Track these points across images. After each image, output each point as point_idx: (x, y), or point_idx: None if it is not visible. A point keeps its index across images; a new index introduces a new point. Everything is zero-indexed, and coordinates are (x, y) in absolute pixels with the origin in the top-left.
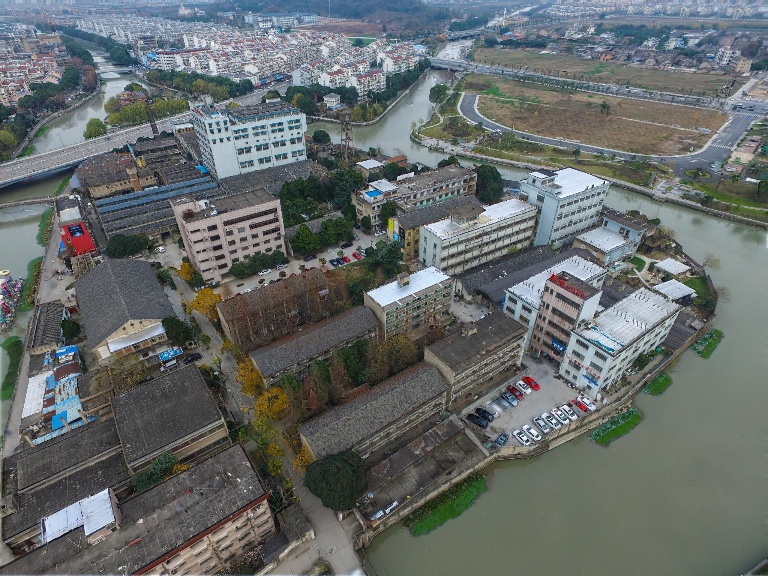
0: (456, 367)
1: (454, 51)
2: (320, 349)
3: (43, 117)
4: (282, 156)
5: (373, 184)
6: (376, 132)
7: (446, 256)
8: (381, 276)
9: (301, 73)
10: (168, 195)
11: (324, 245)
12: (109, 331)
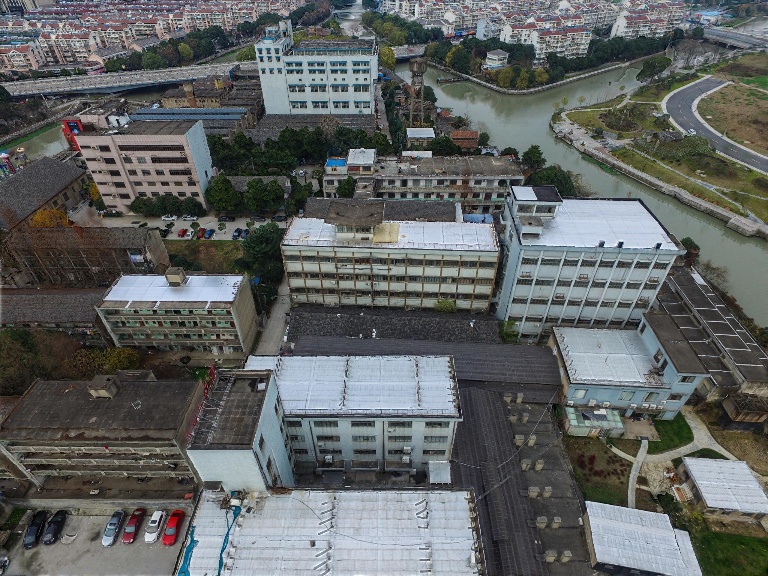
0: (11, 432)
1: (767, 23)
2: (2, 319)
3: (247, 42)
4: (342, 104)
5: (352, 151)
6: (527, 106)
7: (298, 271)
8: (234, 267)
9: (486, 23)
10: (191, 117)
11: (248, 209)
12: None
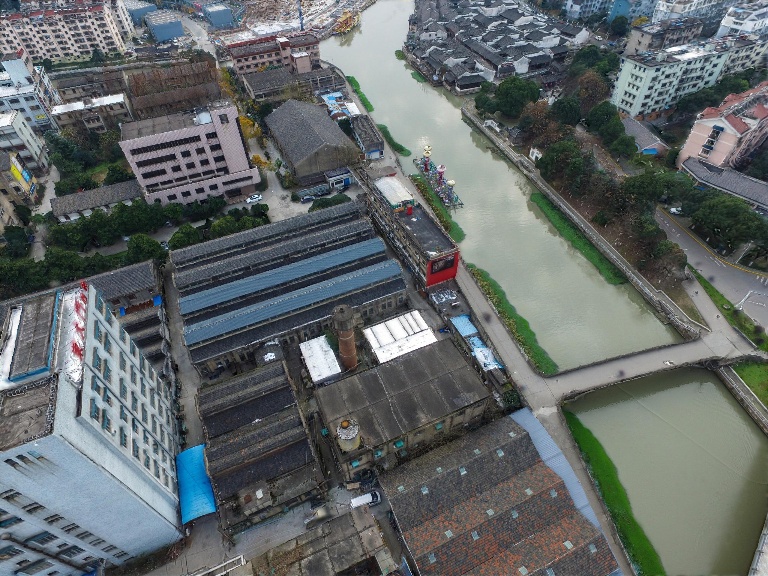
0: None
1: None
2: None
3: None
4: None
5: None
6: None
7: None
8: None
9: None
10: (272, 272)
11: None
12: (307, 104)
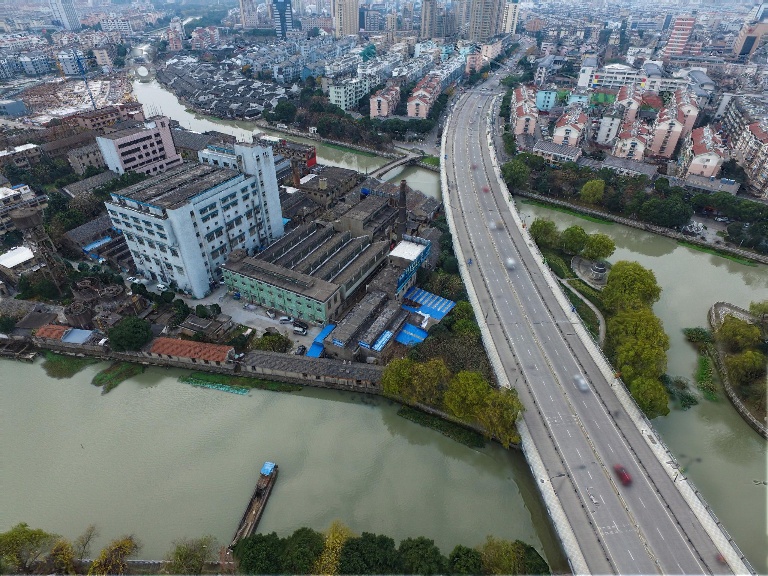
0: None
1: None
2: None
3: None
4: None
5: (15, 191)
6: None
7: None
8: None
9: None
10: None
11: None
12: None
